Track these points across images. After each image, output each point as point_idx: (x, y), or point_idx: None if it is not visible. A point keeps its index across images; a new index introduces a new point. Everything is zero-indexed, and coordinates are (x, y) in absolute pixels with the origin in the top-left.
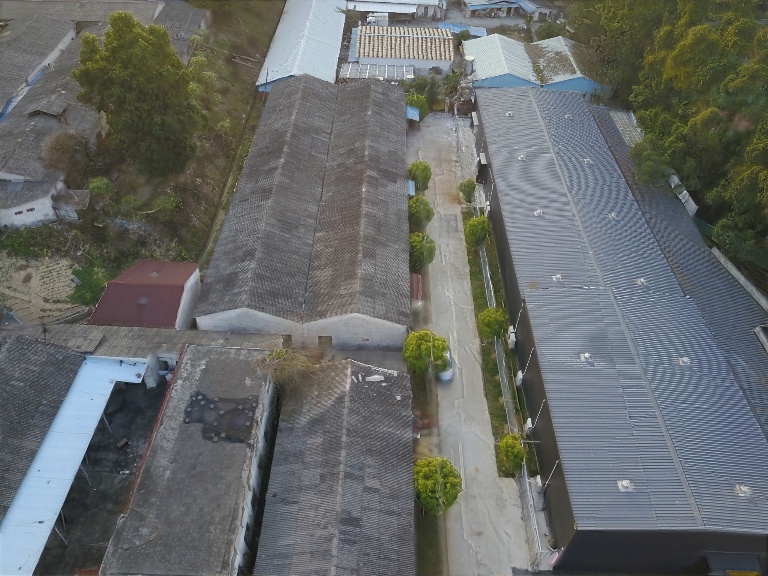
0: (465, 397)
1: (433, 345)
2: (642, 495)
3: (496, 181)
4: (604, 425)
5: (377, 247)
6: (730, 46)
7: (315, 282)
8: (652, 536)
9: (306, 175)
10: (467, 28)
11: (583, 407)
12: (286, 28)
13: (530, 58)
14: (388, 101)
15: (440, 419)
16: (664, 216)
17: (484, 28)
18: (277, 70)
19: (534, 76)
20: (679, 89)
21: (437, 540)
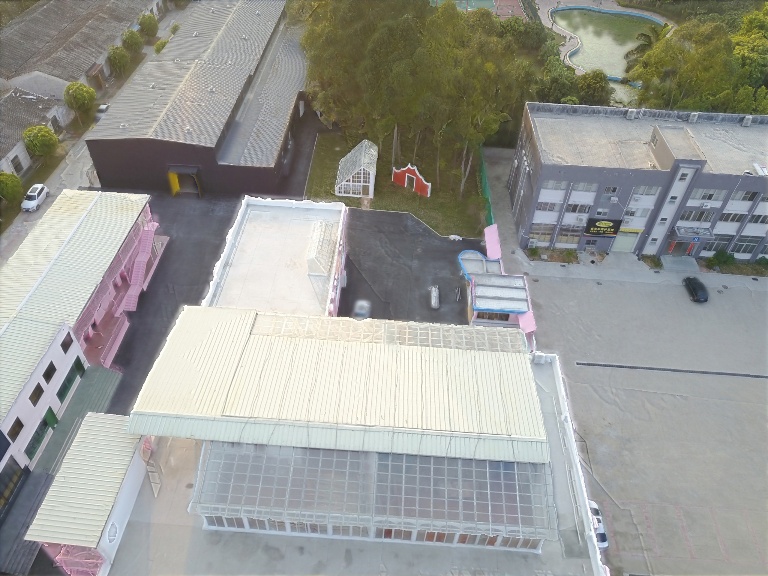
0: None
1: (78, 87)
2: (129, 129)
3: (185, 21)
4: (136, 108)
5: (77, 48)
6: None
7: (28, 63)
8: (129, 147)
9: (60, 17)
10: None
11: (131, 102)
12: None
13: None
14: None
15: (84, 135)
16: (296, 45)
17: None
18: None
19: None
20: None
21: (44, 176)
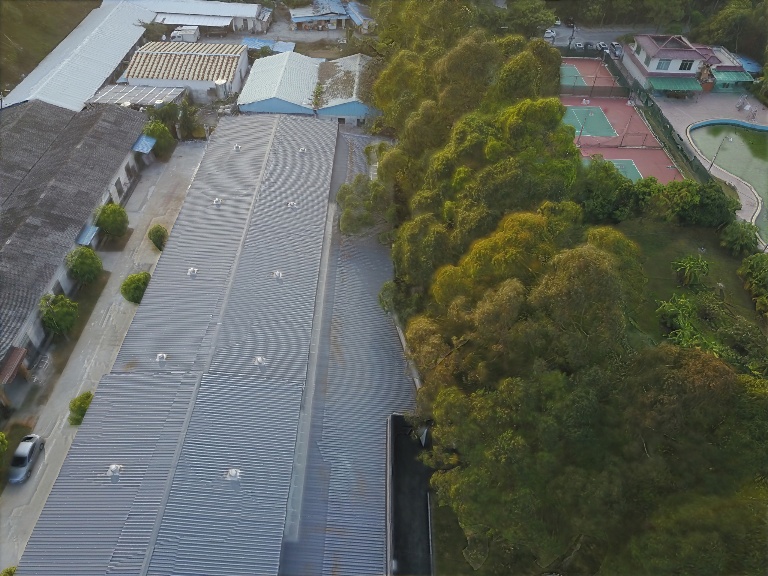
0: (31, 503)
1: None
2: None
3: (172, 230)
4: (74, 569)
5: None
6: (420, 78)
7: None
8: None
9: None
10: (274, 43)
11: (66, 542)
12: (65, 44)
13: (319, 78)
14: (116, 131)
15: None
16: (360, 270)
17: (293, 43)
18: (20, 94)
19: (310, 99)
20: (391, 123)
21: None
